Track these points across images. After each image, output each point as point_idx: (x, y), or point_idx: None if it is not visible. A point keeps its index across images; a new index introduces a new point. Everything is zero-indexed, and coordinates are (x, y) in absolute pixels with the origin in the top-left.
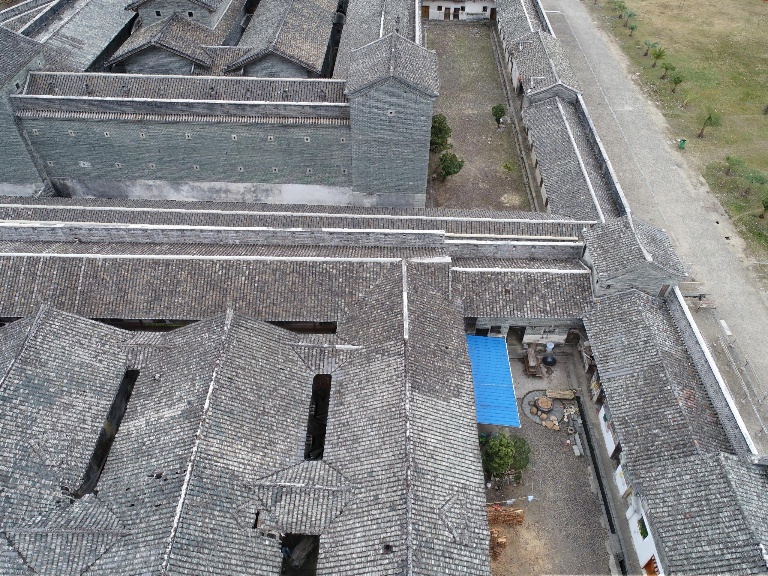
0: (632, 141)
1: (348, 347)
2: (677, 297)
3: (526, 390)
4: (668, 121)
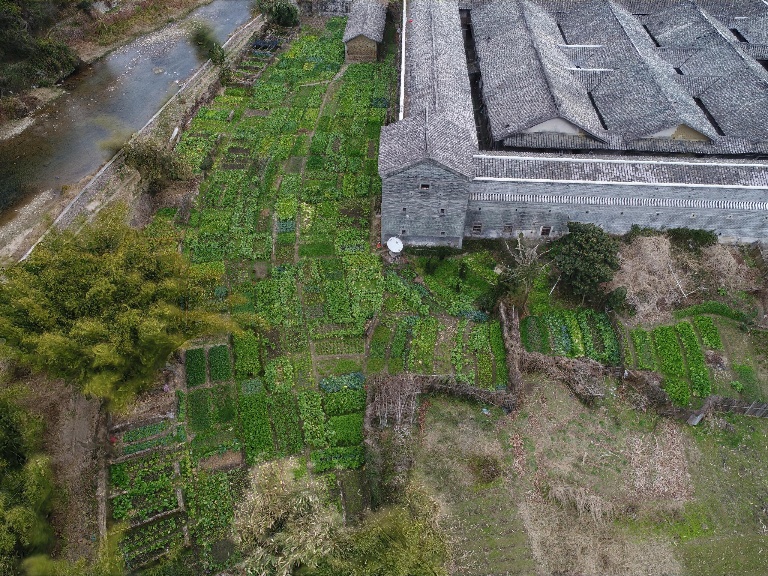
0: None
1: (741, 18)
2: None
3: None
4: None
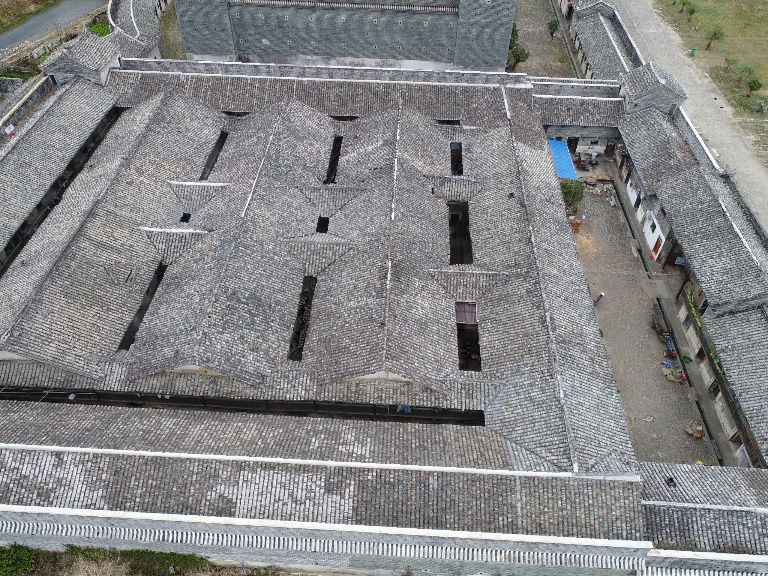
0: (654, 51)
1: (471, 127)
2: (681, 111)
3: (578, 176)
4: (683, 39)
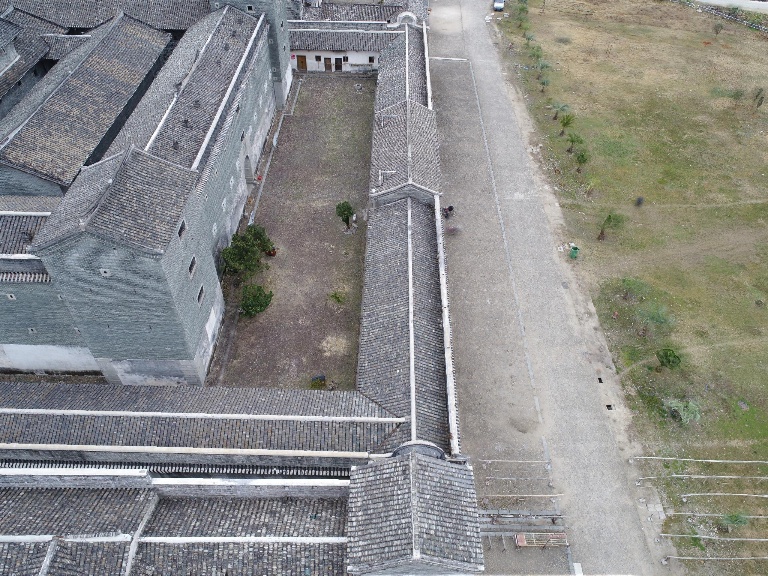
0: (513, 247)
1: None
2: None
3: None
4: (564, 215)
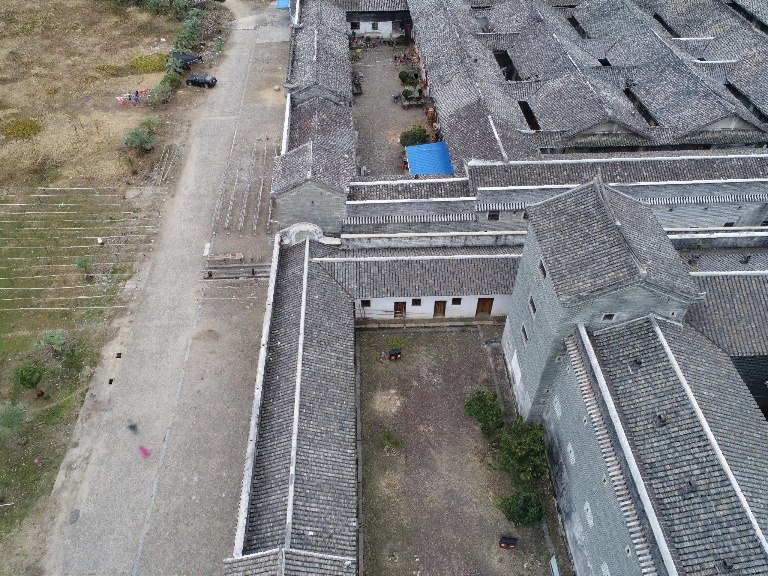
0: None
1: None
2: None
3: None
4: None
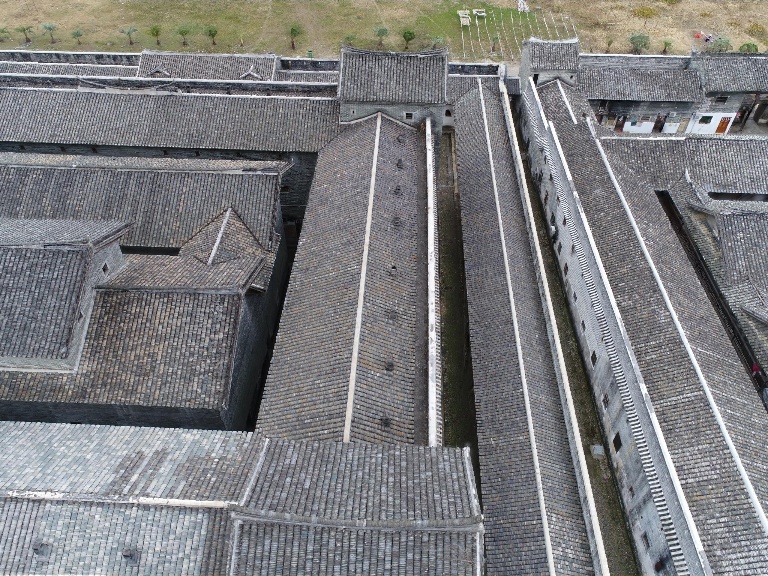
0: None
1: None
2: None
3: None
4: None
